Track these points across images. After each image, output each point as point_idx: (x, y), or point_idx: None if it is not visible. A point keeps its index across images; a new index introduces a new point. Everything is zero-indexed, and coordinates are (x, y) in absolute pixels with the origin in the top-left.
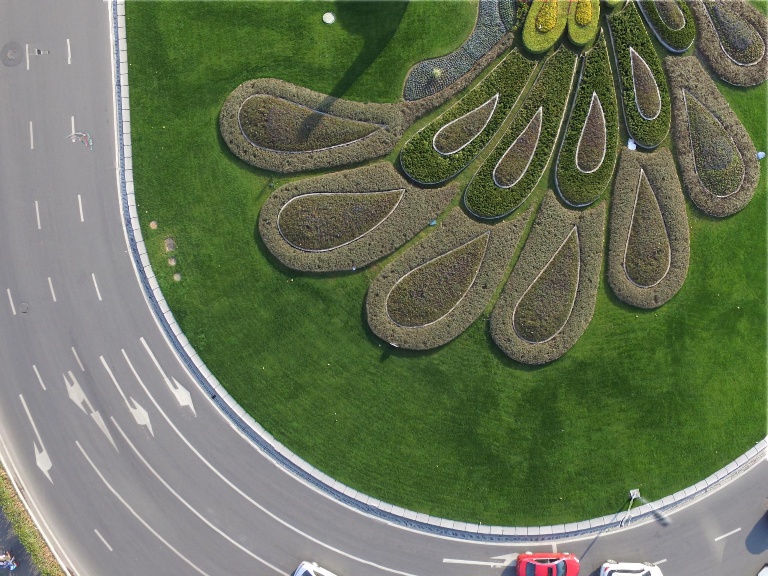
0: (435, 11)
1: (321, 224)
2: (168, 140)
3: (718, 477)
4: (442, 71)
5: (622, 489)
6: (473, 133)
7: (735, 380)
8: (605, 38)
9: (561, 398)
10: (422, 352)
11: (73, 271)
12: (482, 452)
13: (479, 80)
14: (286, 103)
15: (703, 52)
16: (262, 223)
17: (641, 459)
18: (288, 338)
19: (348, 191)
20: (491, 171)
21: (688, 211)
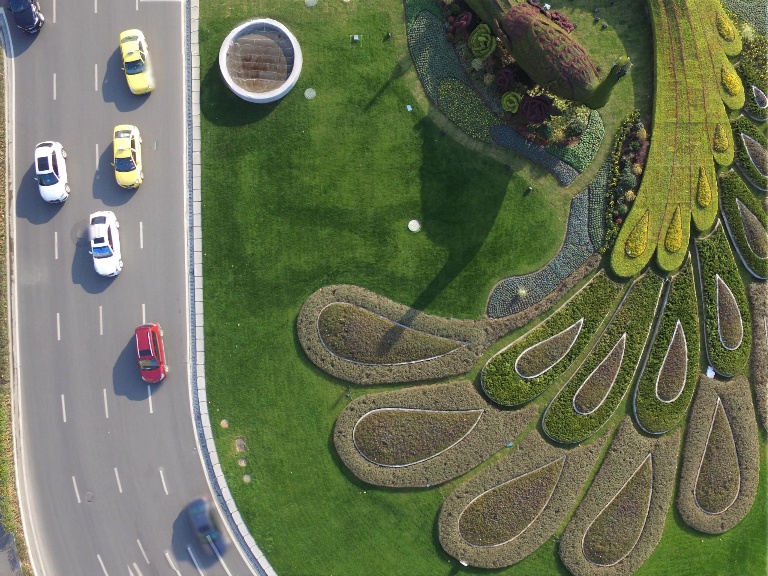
0: (523, 226)
1: (398, 441)
2: (242, 338)
3: None
4: (527, 290)
5: None
6: (556, 358)
7: None
8: (692, 262)
9: None
10: (490, 569)
11: (140, 465)
12: None
13: (564, 301)
14: (367, 314)
15: None
16: (337, 435)
17: None
18: (358, 549)
19: (426, 408)
20: (571, 397)
21: (760, 439)
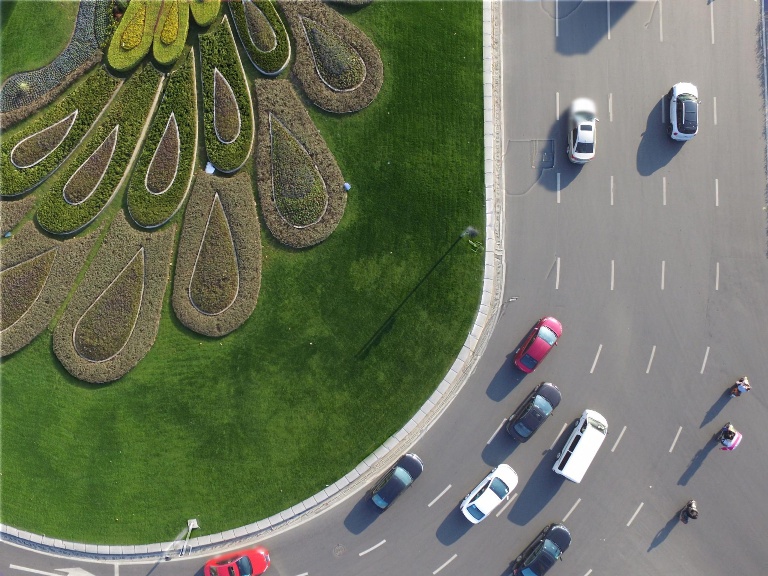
0: (34, 25)
1: None
2: None
3: (283, 516)
4: (31, 85)
5: (179, 517)
6: (48, 148)
7: (303, 418)
8: (196, 58)
9: (119, 419)
10: None
11: None
12: (42, 465)
13: (66, 95)
14: None
15: (296, 76)
16: None
17: (199, 489)
18: None
19: None
20: (62, 187)
21: (264, 240)
